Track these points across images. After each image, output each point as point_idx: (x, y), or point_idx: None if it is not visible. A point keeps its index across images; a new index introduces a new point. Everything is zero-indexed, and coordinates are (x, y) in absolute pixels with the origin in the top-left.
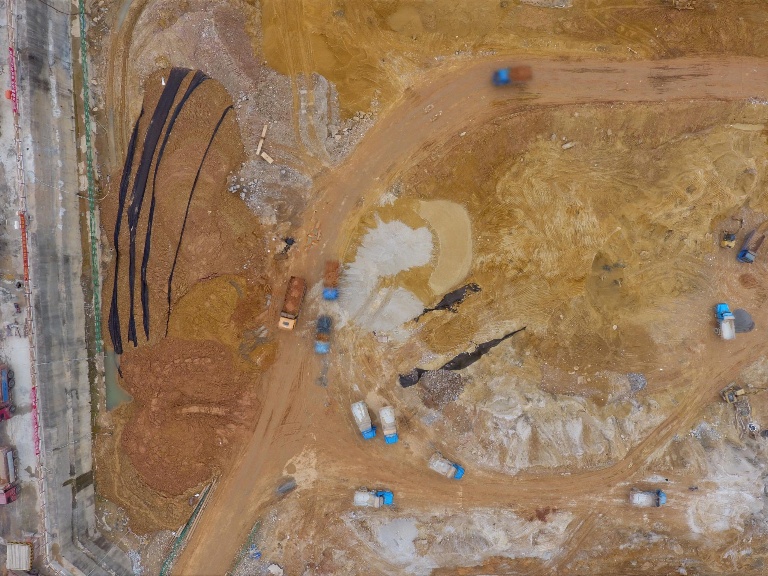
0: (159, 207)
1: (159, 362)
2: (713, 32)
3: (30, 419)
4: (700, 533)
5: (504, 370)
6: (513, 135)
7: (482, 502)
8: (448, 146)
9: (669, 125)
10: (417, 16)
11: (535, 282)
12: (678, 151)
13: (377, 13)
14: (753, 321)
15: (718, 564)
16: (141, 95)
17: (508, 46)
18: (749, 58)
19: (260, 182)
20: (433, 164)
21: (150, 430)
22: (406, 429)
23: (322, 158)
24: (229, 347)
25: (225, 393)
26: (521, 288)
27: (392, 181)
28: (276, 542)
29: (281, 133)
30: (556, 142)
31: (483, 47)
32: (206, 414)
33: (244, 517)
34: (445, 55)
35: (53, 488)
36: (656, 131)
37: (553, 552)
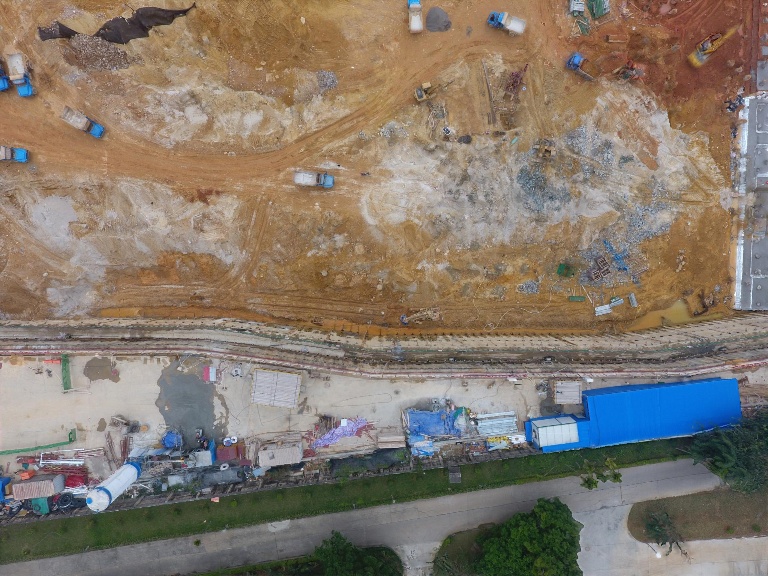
0: None
1: None
2: None
3: None
4: (375, 225)
5: (185, 61)
6: None
7: (132, 172)
8: None
9: None
10: None
11: None
12: None
13: None
14: (450, 20)
15: (406, 271)
16: None
17: None
18: None
19: None
20: None
21: None
22: (47, 88)
23: None
24: None
25: None
26: None
27: None
28: None
29: None
30: None
31: None
32: None
33: None
34: None
35: None
36: None
37: (235, 255)
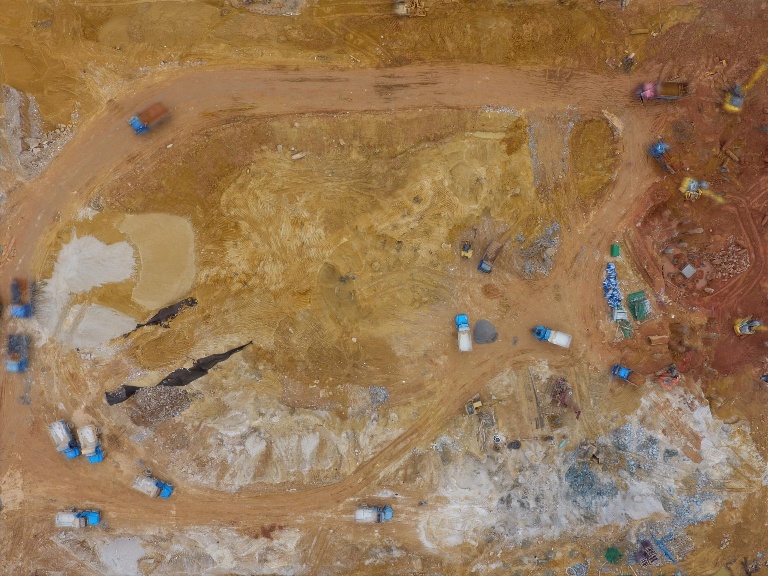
0: None
1: None
2: (440, 39)
3: None
4: (433, 548)
5: (241, 384)
6: (231, 146)
7: (199, 520)
8: (155, 158)
9: (403, 134)
10: (124, 26)
11: (258, 295)
12: (416, 160)
13: (88, 23)
14: (496, 332)
15: None
16: None
17: (218, 56)
18: (480, 66)
19: None
20: (138, 177)
21: None
22: (116, 447)
23: (16, 172)
24: None
25: None
26: (242, 302)
27: (91, 195)
28: None
29: None
30: (285, 152)
31: (191, 57)
32: None
33: None
34: (150, 65)
35: None
36: (391, 140)
37: (296, 568)
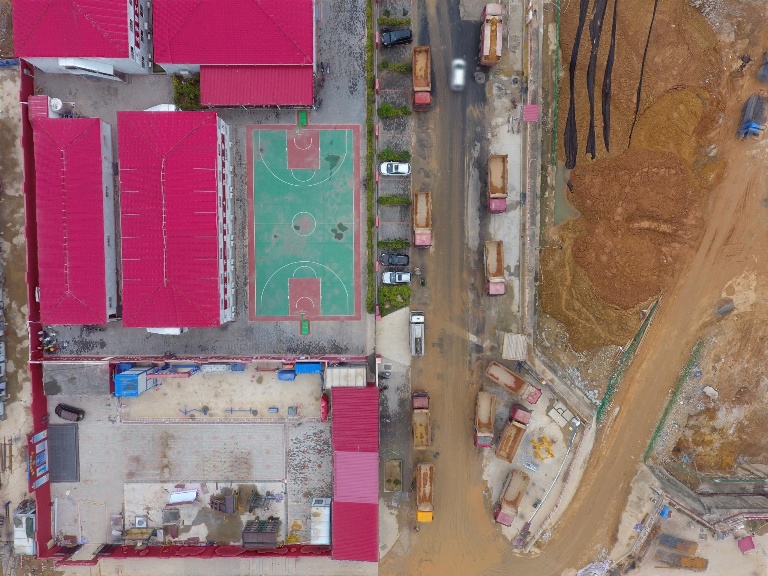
0: (623, 20)
1: (627, 170)
2: None
3: (514, 217)
4: None
5: None
6: None
7: None
8: None
9: None
10: None
11: None
12: None
13: None
14: None
15: None
16: None
17: None
18: None
19: None
20: None
21: (611, 240)
22: None
23: None
24: (686, 162)
25: (676, 209)
26: None
27: None
28: (710, 364)
29: None
30: None
31: None
32: (653, 231)
33: (686, 336)
34: None
35: (532, 287)
36: None
37: None
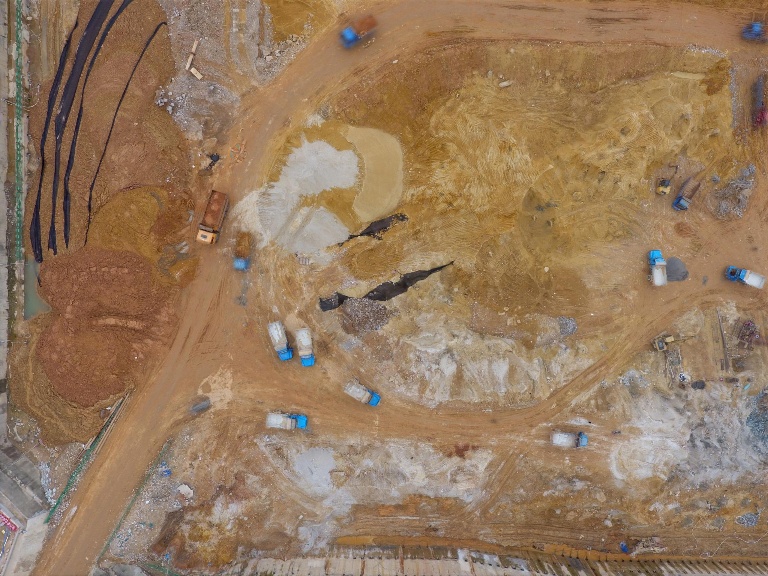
0: (86, 117)
1: (75, 269)
2: None
3: None
4: (622, 479)
5: (433, 307)
6: (448, 68)
7: (399, 433)
8: (380, 73)
9: (608, 68)
10: None
11: (464, 216)
12: (617, 96)
13: None
14: (687, 270)
15: (642, 515)
16: (76, 8)
17: None
18: (689, 5)
19: (188, 97)
20: (364, 90)
21: (63, 338)
22: (324, 354)
23: (251, 77)
24: (148, 260)
25: (142, 306)
26: (449, 221)
27: (321, 103)
28: (188, 462)
29: (212, 50)
30: (493, 79)
31: None
32: (123, 327)
33: (155, 434)
34: None
35: None
36: (595, 74)
37: (475, 495)
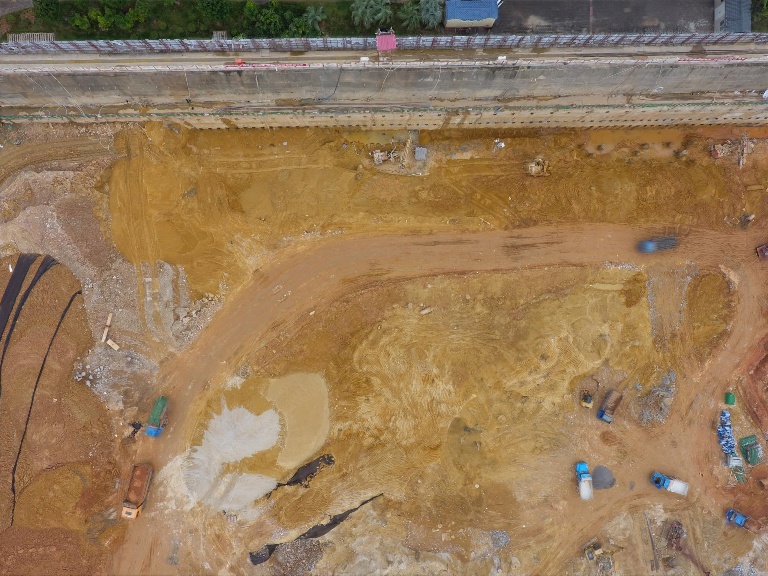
0: (5, 396)
1: (3, 552)
2: (566, 201)
3: None
4: None
5: (368, 530)
6: (366, 308)
7: None
8: (297, 325)
9: (527, 289)
10: (267, 196)
11: (391, 451)
12: (538, 312)
13: (230, 190)
14: (614, 477)
15: None
16: None
17: (357, 224)
18: (603, 224)
19: (106, 369)
20: (282, 344)
21: None
22: None
23: (168, 343)
24: (76, 532)
25: (74, 575)
26: (376, 458)
27: (239, 364)
28: None
29: (127, 320)
30: (414, 308)
31: (332, 226)
32: None
33: None
34: (294, 236)
35: None
36: (515, 294)
37: None
